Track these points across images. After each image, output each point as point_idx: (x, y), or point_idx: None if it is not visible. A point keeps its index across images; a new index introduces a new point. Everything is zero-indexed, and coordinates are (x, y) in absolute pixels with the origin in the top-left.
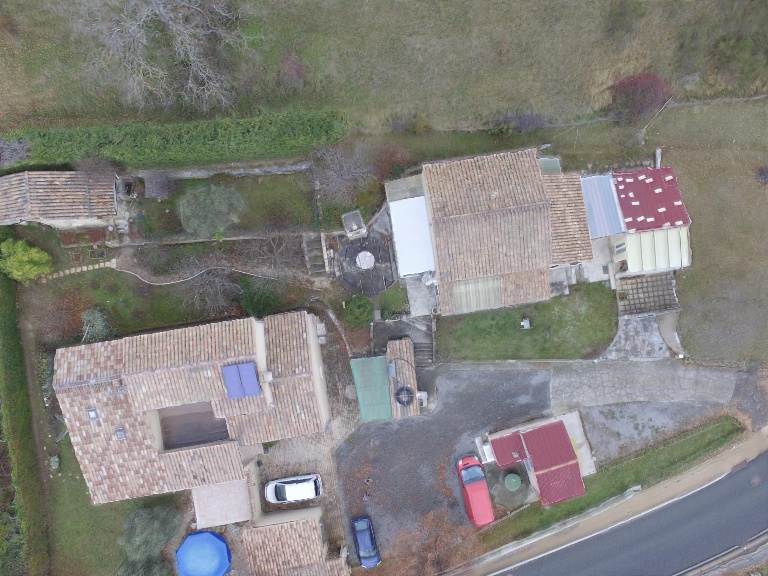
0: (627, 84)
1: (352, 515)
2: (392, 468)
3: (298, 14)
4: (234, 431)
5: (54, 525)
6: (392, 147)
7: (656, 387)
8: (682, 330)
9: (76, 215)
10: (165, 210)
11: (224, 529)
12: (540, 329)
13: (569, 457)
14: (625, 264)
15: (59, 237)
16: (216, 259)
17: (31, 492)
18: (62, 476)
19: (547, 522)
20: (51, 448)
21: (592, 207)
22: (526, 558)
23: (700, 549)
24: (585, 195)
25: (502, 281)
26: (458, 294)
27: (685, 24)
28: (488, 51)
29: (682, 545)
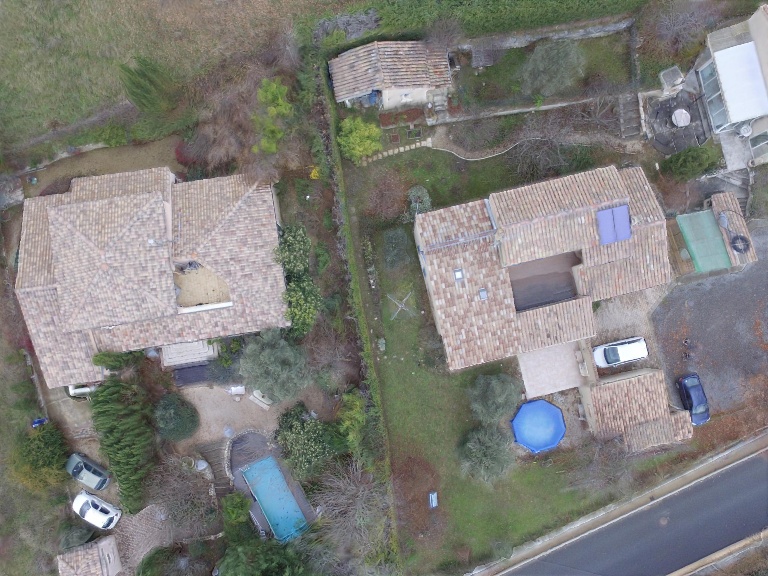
0: None
1: (677, 375)
2: (709, 327)
3: None
4: (585, 287)
5: (385, 406)
6: (705, 1)
7: None
8: None
9: (421, 83)
10: (481, 83)
11: (551, 398)
12: None
13: None
14: None
15: (378, 119)
16: (529, 131)
17: None
18: (388, 358)
19: None
20: (378, 330)
21: None
22: None
23: None
24: None
25: None
26: None
27: None
28: None
29: None
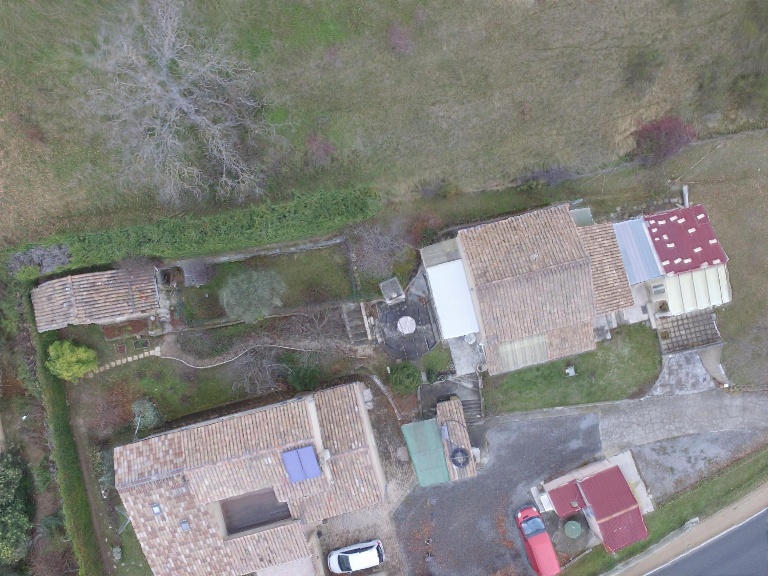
0: (650, 128)
1: None
2: (451, 526)
3: (321, 95)
4: (296, 511)
5: None
6: (423, 212)
7: (704, 418)
8: (725, 361)
9: (121, 313)
10: (204, 295)
11: None
12: (585, 375)
13: (629, 503)
14: (665, 305)
15: (102, 331)
16: (258, 337)
17: None
18: (125, 565)
19: (610, 564)
20: (112, 539)
21: (628, 253)
22: None
23: (764, 575)
24: (619, 241)
25: (547, 336)
26: (504, 353)
27: (703, 65)
28: (511, 111)
29: (745, 573)
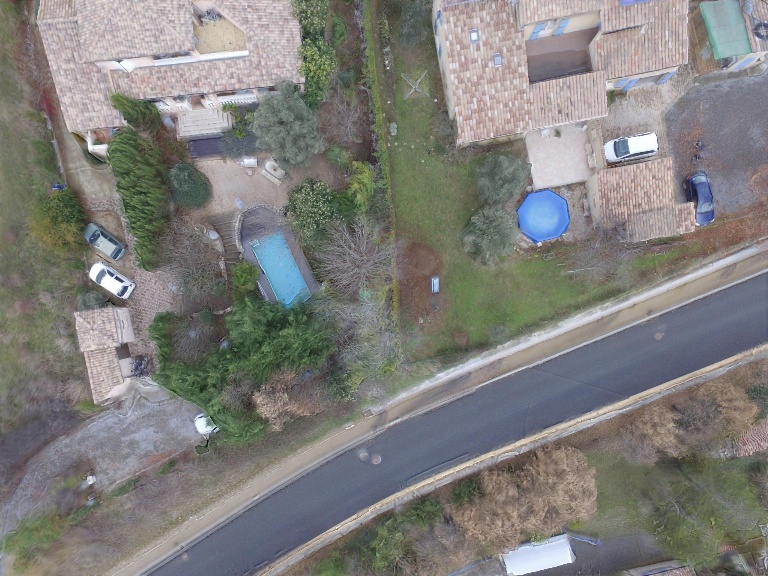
0: None
1: (685, 175)
2: (722, 131)
3: None
4: (601, 62)
5: (393, 192)
6: None
7: None
8: None
9: None
10: None
11: (558, 192)
12: None
13: None
14: None
15: None
16: None
17: None
18: (398, 145)
19: None
20: (390, 114)
21: None
22: None
23: None
24: None
25: None
26: None
27: None
28: None
29: None
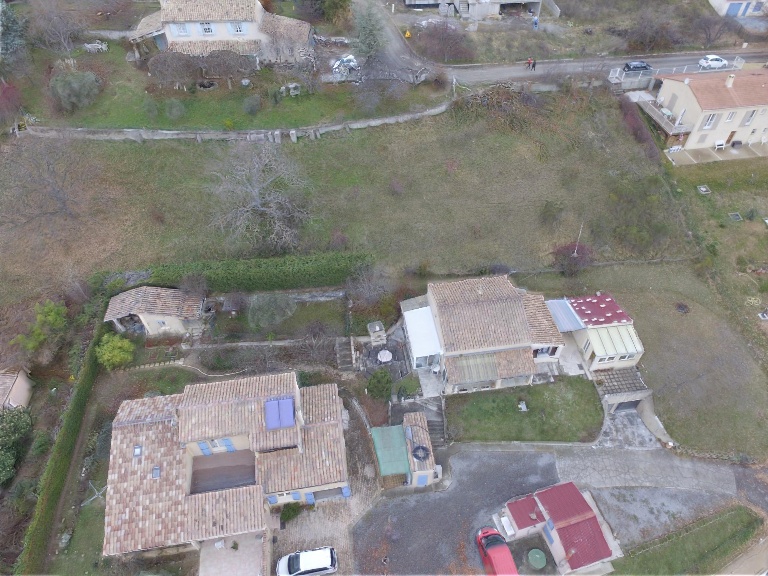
0: (562, 250)
1: None
2: (410, 546)
3: (345, 213)
4: (261, 477)
5: None
6: (405, 285)
7: (658, 474)
8: (662, 417)
9: (171, 313)
10: None
11: None
12: (536, 411)
13: (586, 511)
14: (593, 354)
15: (146, 341)
16: None
17: (37, 554)
18: (68, 553)
19: None
20: (69, 520)
21: (556, 315)
22: None
23: None
24: (549, 310)
25: (495, 358)
26: (461, 367)
27: (590, 220)
28: (466, 232)
29: None
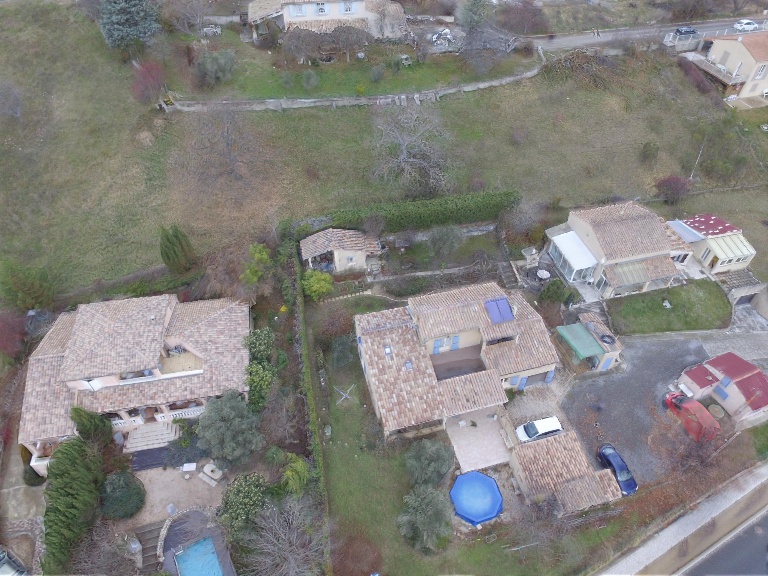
0: None
1: (595, 450)
2: (612, 413)
3: (476, 162)
4: (492, 364)
5: (328, 485)
6: (541, 218)
7: None
8: None
9: (360, 249)
10: None
11: None
12: (678, 307)
13: (752, 369)
14: (714, 258)
15: None
16: (440, 284)
17: None
18: (333, 444)
19: (763, 450)
20: (325, 418)
21: (677, 232)
22: (762, 506)
23: None
24: None
25: (644, 264)
26: (619, 273)
27: (680, 157)
28: (582, 172)
29: None
